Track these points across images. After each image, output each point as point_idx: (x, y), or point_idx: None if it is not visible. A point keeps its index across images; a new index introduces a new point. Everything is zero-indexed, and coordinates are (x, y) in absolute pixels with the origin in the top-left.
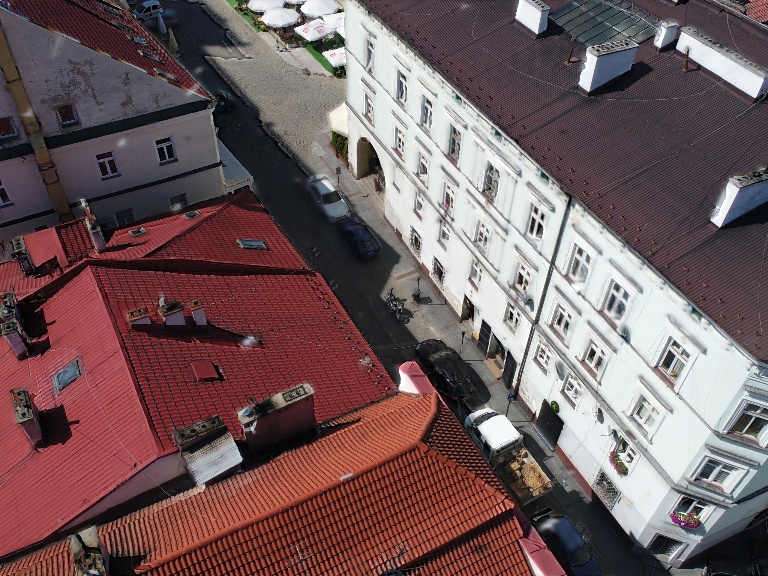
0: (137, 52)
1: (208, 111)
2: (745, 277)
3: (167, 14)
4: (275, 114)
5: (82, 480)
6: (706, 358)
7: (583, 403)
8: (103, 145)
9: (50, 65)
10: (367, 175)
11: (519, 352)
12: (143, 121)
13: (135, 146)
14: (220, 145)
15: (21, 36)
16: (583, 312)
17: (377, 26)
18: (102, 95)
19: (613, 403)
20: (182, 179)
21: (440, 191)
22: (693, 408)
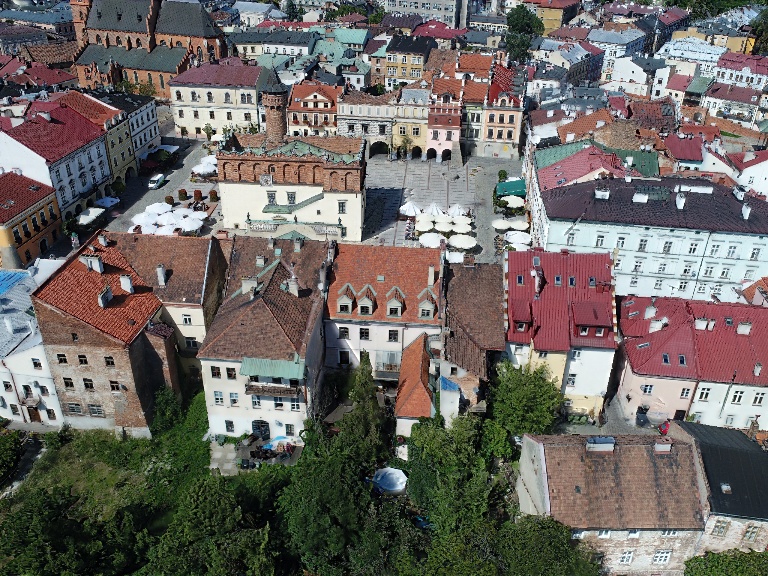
0: None
1: None
2: (763, 225)
3: None
4: None
5: (767, 328)
6: (767, 246)
7: (725, 290)
8: None
9: None
10: None
11: (690, 295)
12: None
13: None
14: None
15: None
16: (720, 262)
17: (583, 225)
18: None
19: (737, 281)
20: None
21: (633, 266)
22: (766, 261)
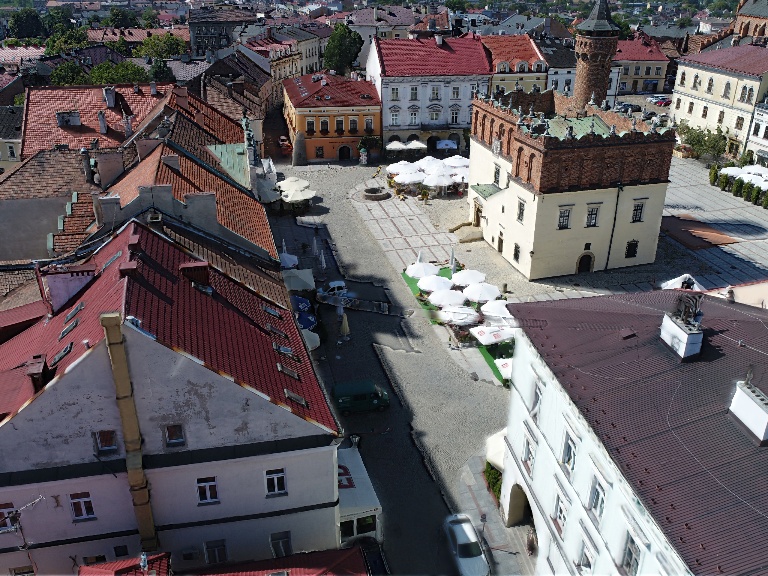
0: (275, 366)
1: (331, 447)
2: None
3: (350, 295)
4: (429, 422)
5: None
6: None
7: None
8: (206, 469)
9: (167, 384)
10: (520, 524)
11: None
12: (255, 450)
13: (242, 474)
14: (356, 458)
15: (144, 354)
16: None
17: (548, 374)
18: (216, 418)
19: None
20: (289, 515)
21: None
22: None
